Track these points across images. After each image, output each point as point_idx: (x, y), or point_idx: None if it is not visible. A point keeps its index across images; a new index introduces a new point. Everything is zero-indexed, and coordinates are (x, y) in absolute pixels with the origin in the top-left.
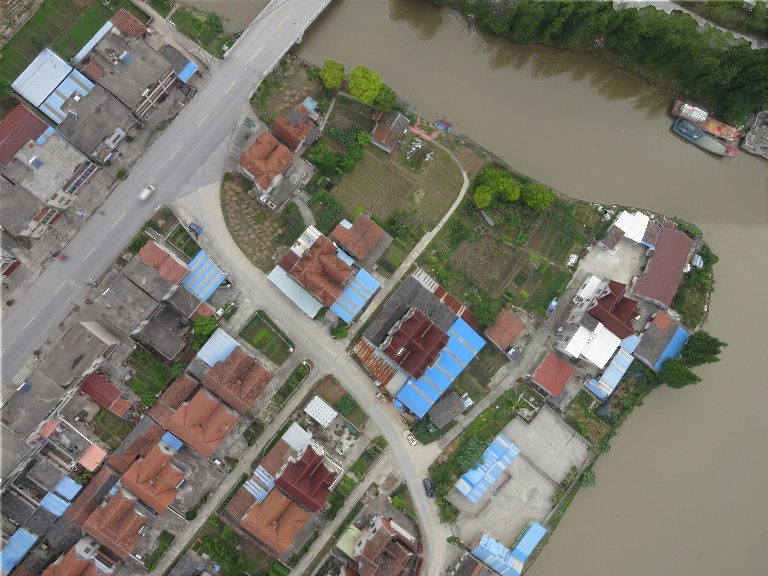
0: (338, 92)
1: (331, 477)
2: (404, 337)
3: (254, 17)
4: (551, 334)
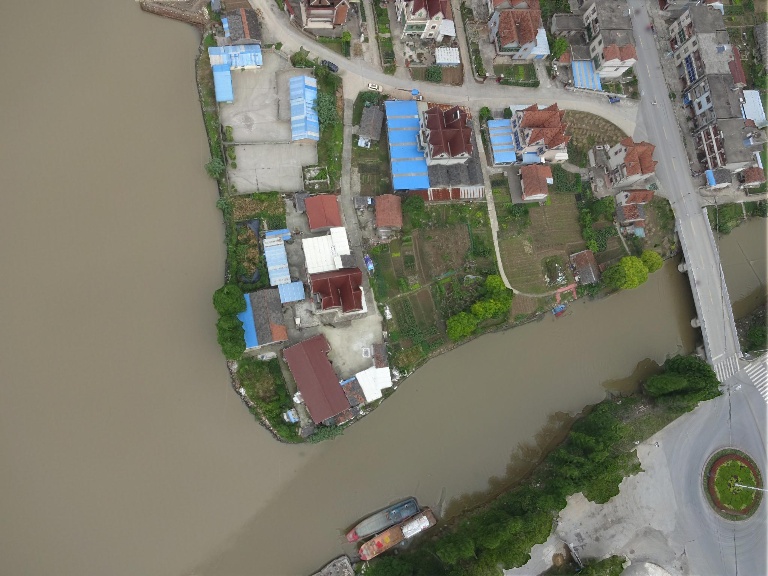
0: None
1: (417, 7)
2: (463, 127)
3: None
4: (350, 244)
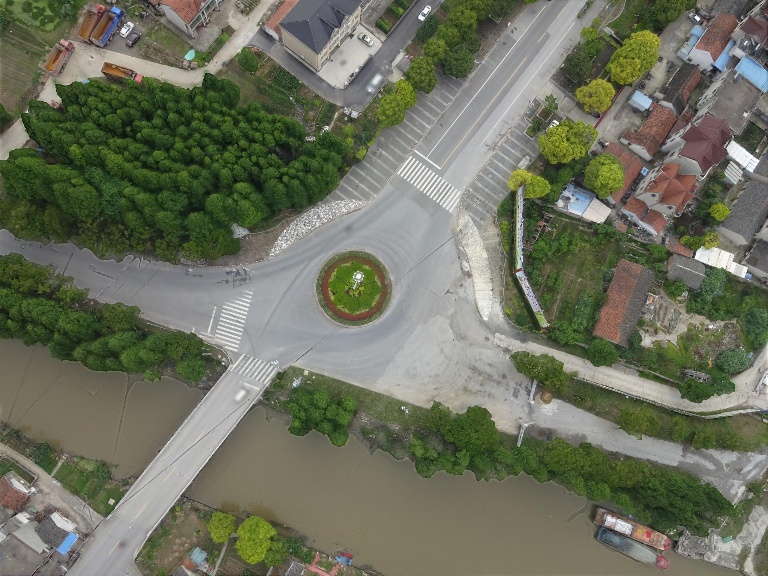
0: (231, 534)
1: None
2: None
3: (147, 451)
4: None
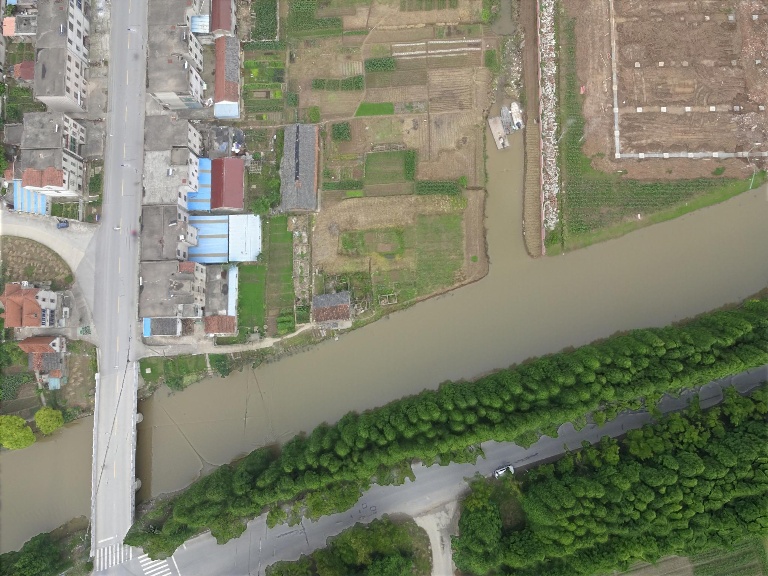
0: None
1: None
2: None
3: (163, 417)
4: None
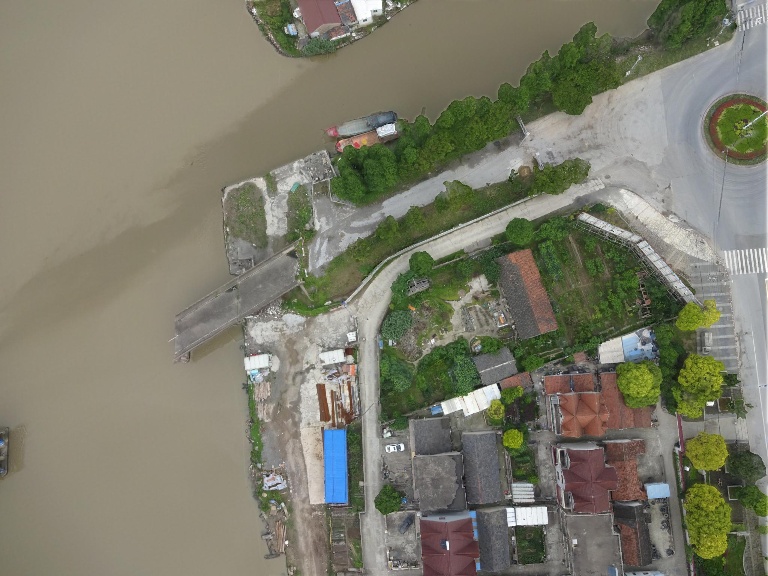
0: None
1: None
2: None
3: None
4: None
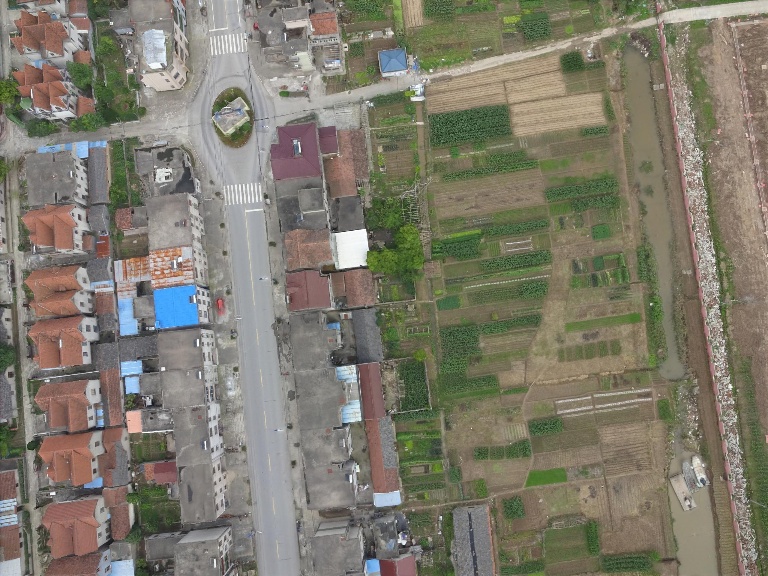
0: None
1: None
2: None
3: None
4: None
